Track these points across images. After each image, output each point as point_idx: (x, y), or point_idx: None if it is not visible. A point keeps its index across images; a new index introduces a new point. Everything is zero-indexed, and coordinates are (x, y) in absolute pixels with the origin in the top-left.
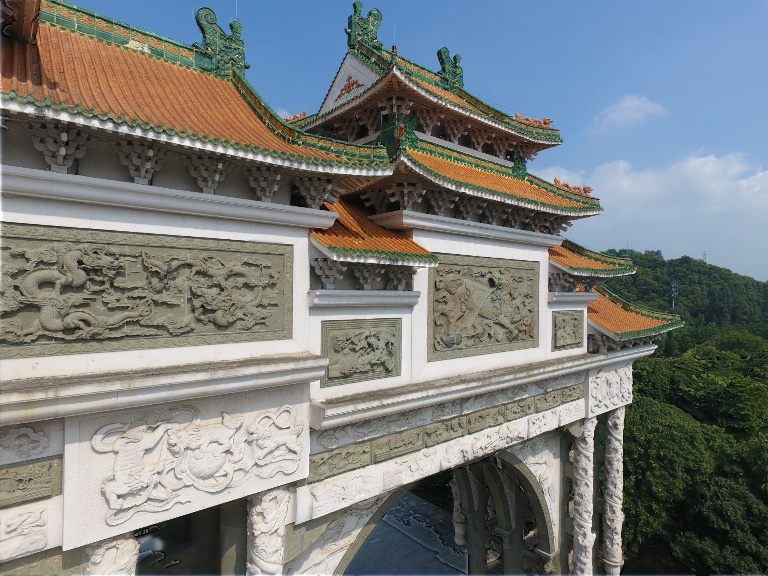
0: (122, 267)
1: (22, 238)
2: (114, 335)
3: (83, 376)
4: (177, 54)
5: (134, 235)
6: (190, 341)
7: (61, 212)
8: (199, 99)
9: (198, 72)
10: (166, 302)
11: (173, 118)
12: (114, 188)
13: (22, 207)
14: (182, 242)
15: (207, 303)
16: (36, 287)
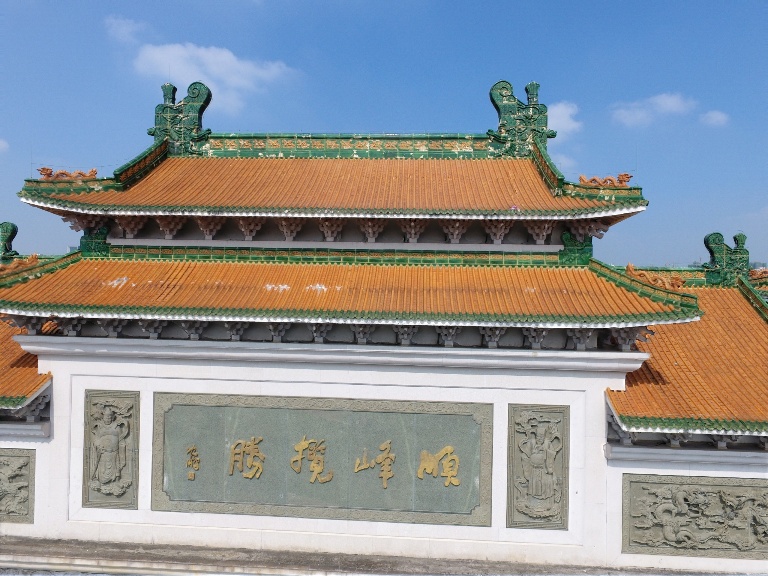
0: (710, 503)
1: (654, 483)
2: (703, 547)
3: (687, 572)
4: (692, 278)
5: (715, 478)
6: (753, 555)
7: (674, 466)
8: (731, 337)
9: (709, 288)
10: (737, 526)
11: (735, 386)
12: (709, 455)
13: (654, 465)
14: (747, 482)
15: (767, 530)
16: (662, 514)
